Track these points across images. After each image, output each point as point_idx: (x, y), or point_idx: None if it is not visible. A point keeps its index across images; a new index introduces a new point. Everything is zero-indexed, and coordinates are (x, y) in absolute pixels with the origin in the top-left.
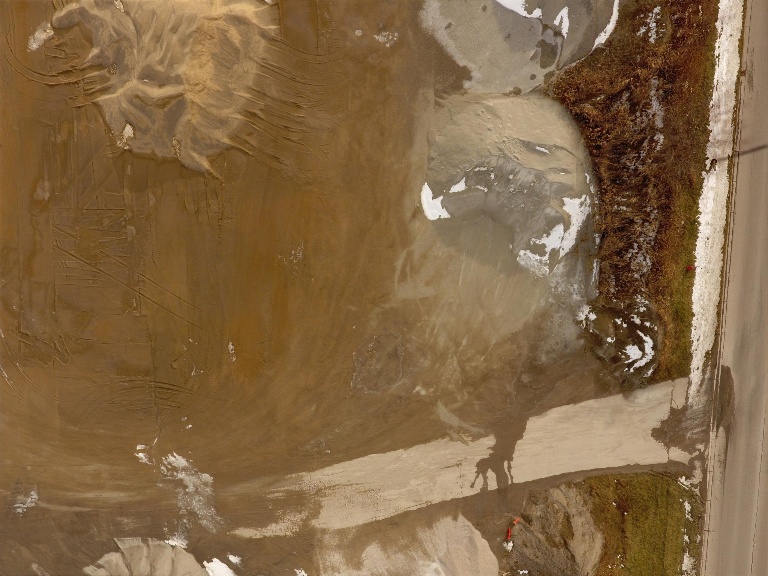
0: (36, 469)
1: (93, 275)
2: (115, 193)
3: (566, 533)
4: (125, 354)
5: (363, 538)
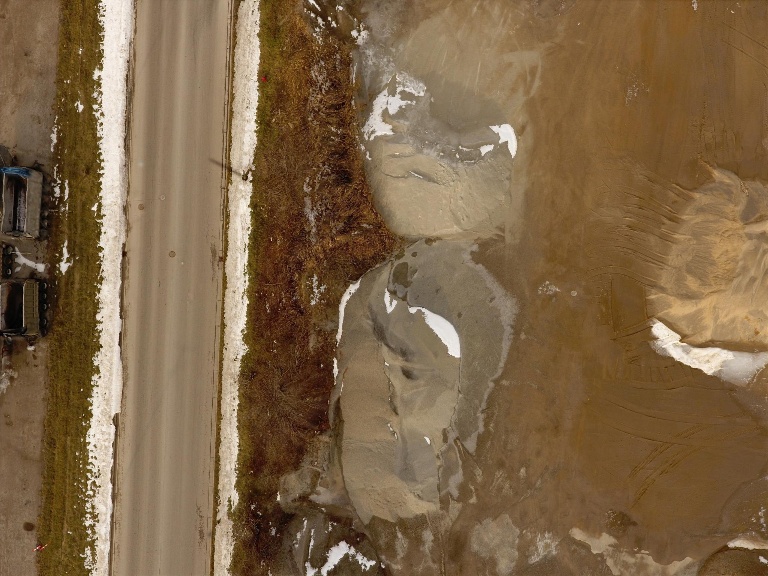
0: None
1: None
2: None
3: None
4: None
5: None
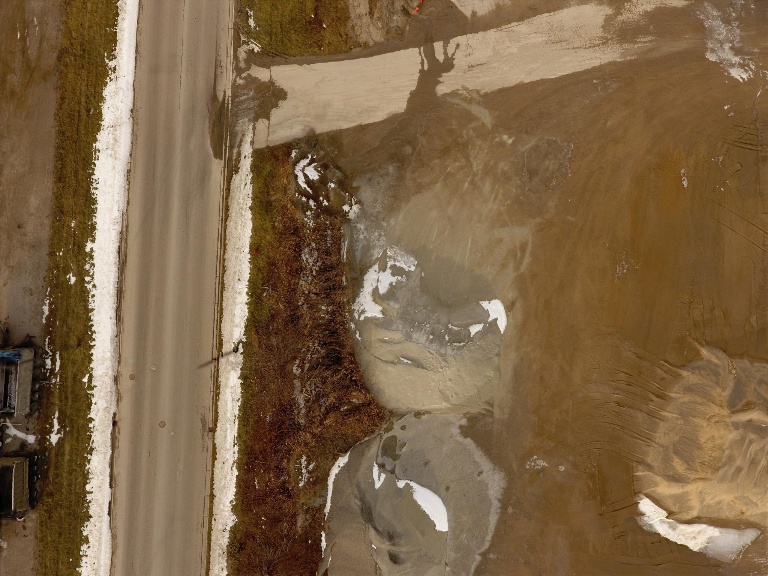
0: None
1: None
2: None
3: None
4: None
5: None
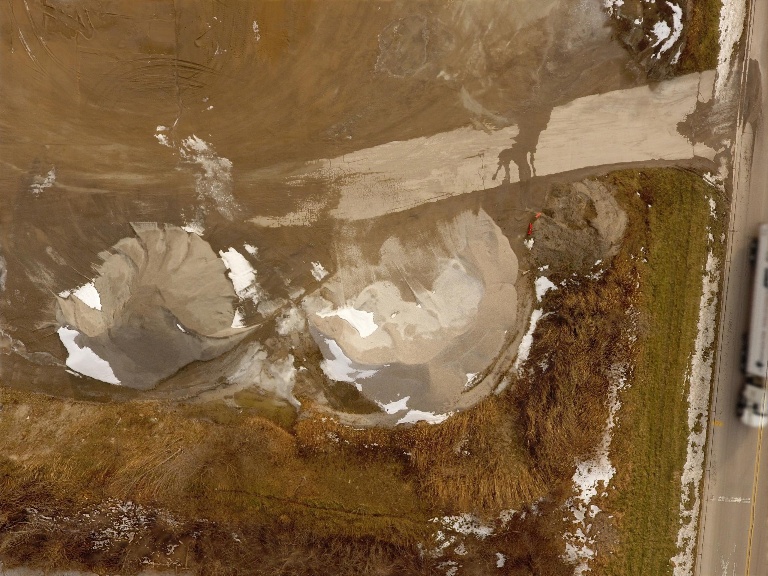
0: (55, 148)
1: None
2: None
3: (589, 215)
4: (149, 30)
5: (382, 231)
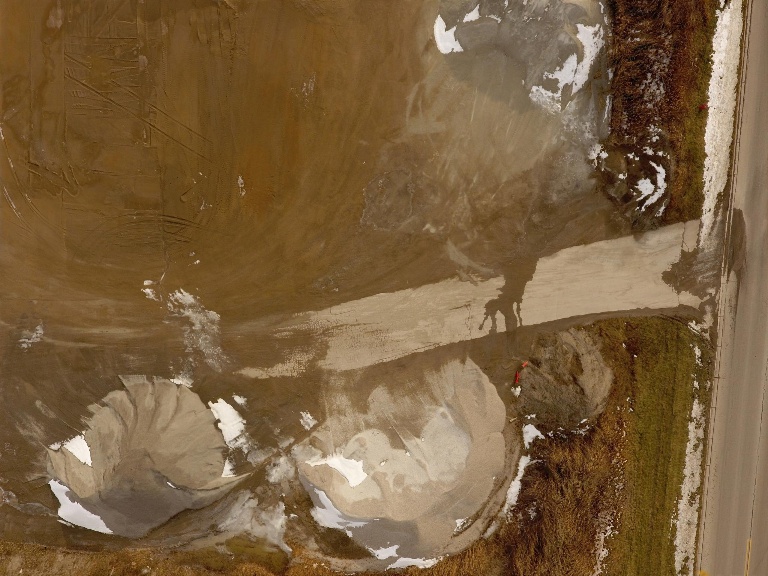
0: (42, 303)
1: (104, 105)
2: (128, 22)
3: (575, 370)
4: (134, 186)
5: (370, 380)
